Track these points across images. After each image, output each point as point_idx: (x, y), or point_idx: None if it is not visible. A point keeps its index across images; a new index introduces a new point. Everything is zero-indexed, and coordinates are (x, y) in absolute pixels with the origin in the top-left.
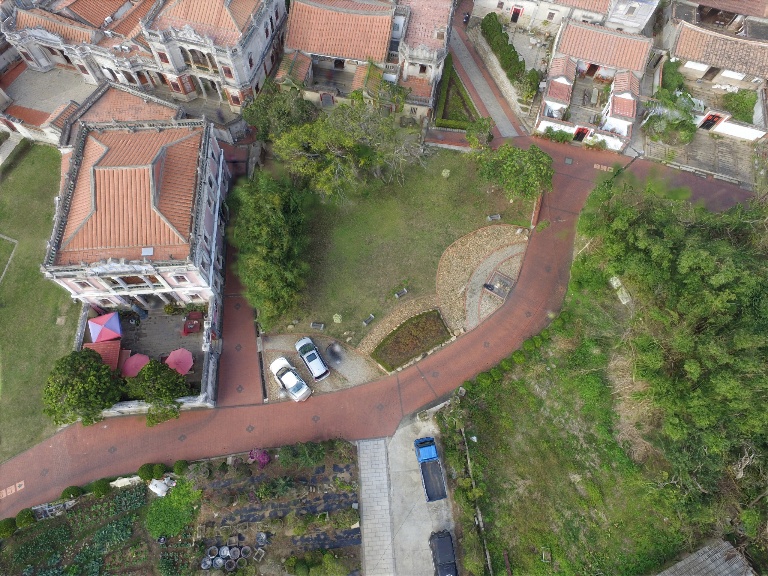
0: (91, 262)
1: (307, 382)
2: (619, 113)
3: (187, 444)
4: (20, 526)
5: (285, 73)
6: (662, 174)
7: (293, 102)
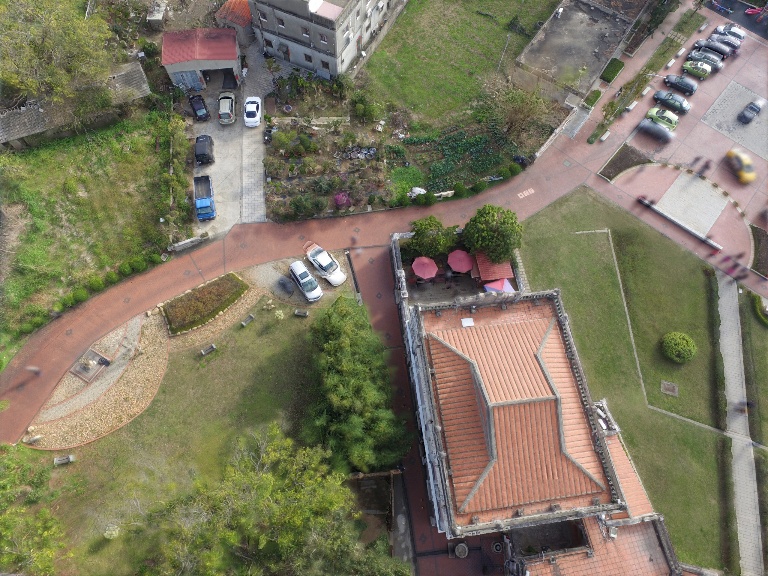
0: (520, 309)
1: (311, 266)
2: None
3: (406, 220)
4: (505, 168)
5: None
6: None
7: (316, 549)
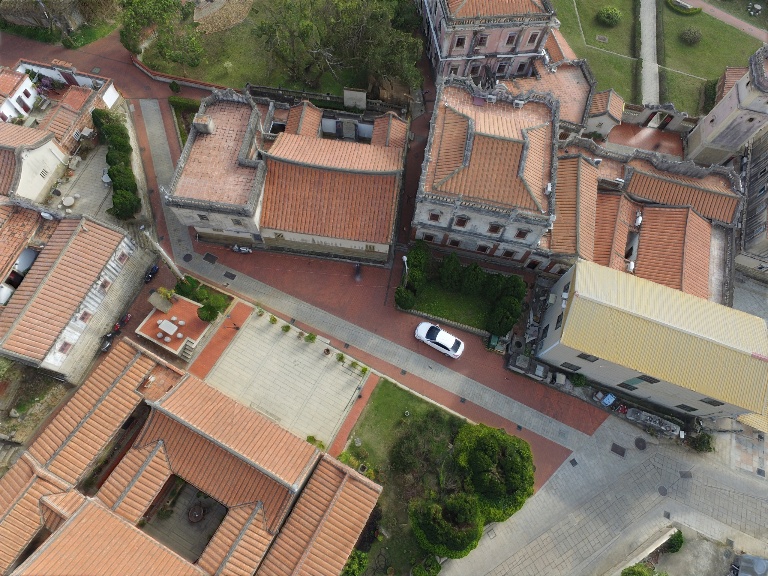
0: None
1: None
2: (17, 73)
3: None
4: None
5: (396, 123)
6: (2, 56)
7: None
